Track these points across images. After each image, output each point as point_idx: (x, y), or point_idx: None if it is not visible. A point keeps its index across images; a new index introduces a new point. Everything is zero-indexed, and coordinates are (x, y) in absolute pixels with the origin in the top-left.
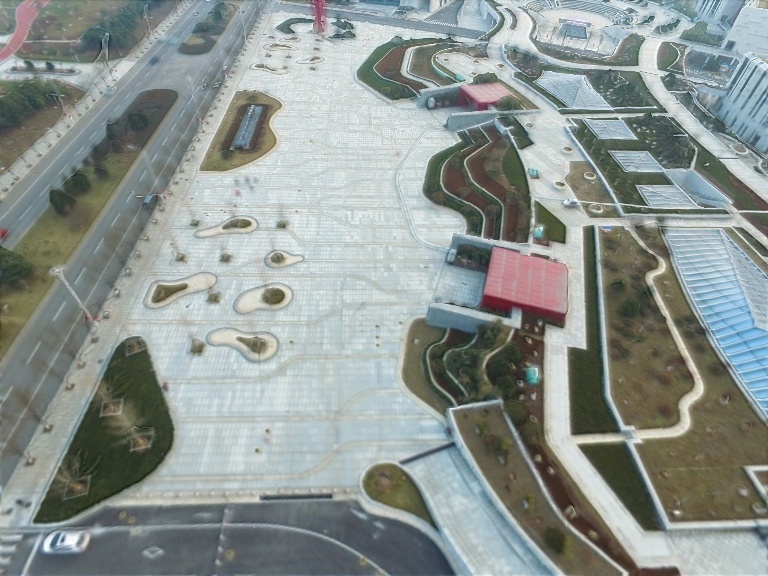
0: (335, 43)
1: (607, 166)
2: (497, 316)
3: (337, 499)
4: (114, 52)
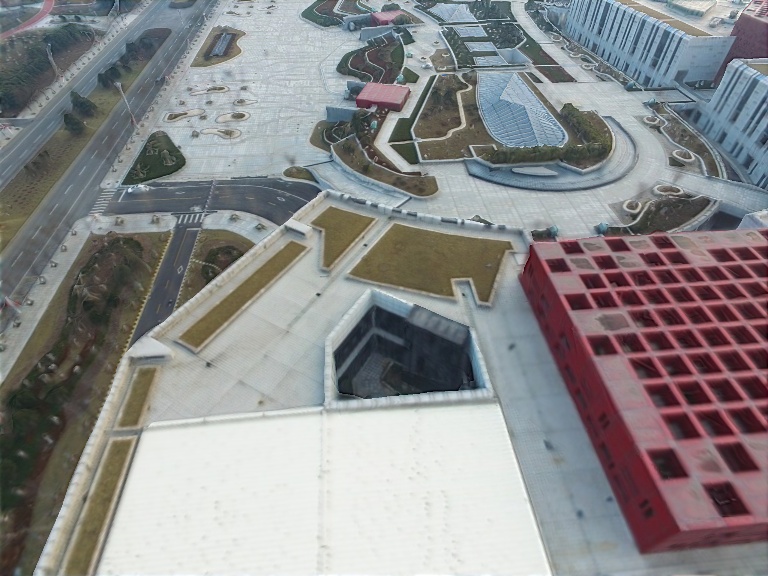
0: None
1: (458, 49)
2: None
3: (270, 178)
4: (122, 9)
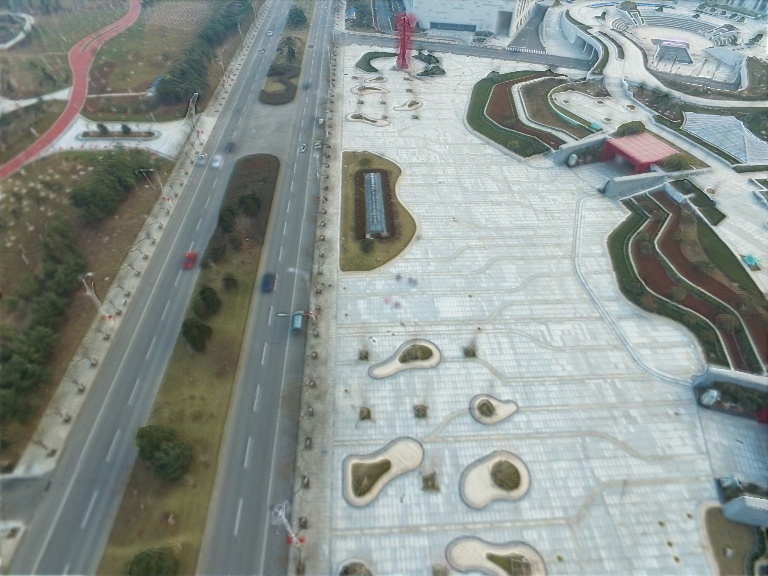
0: (426, 82)
1: None
2: None
3: None
4: None
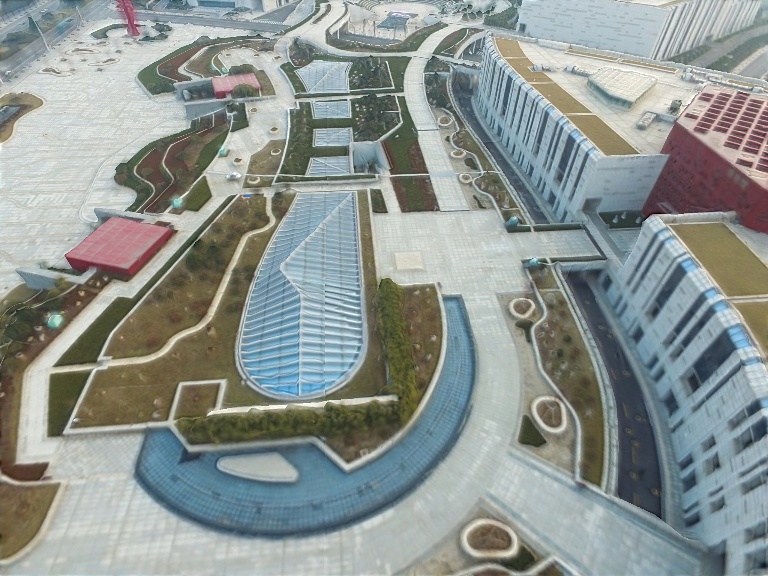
0: (142, 45)
1: (295, 142)
2: (68, 275)
3: None
4: None
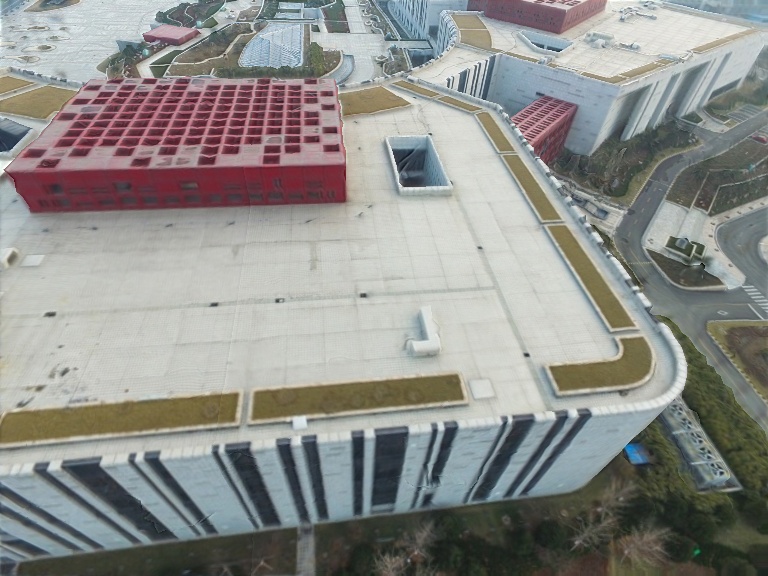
0: None
1: (267, 6)
2: None
3: None
4: None
